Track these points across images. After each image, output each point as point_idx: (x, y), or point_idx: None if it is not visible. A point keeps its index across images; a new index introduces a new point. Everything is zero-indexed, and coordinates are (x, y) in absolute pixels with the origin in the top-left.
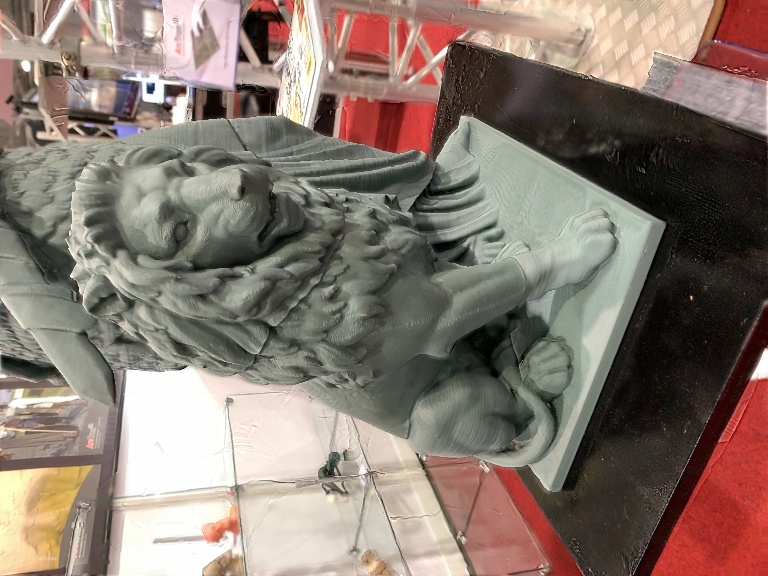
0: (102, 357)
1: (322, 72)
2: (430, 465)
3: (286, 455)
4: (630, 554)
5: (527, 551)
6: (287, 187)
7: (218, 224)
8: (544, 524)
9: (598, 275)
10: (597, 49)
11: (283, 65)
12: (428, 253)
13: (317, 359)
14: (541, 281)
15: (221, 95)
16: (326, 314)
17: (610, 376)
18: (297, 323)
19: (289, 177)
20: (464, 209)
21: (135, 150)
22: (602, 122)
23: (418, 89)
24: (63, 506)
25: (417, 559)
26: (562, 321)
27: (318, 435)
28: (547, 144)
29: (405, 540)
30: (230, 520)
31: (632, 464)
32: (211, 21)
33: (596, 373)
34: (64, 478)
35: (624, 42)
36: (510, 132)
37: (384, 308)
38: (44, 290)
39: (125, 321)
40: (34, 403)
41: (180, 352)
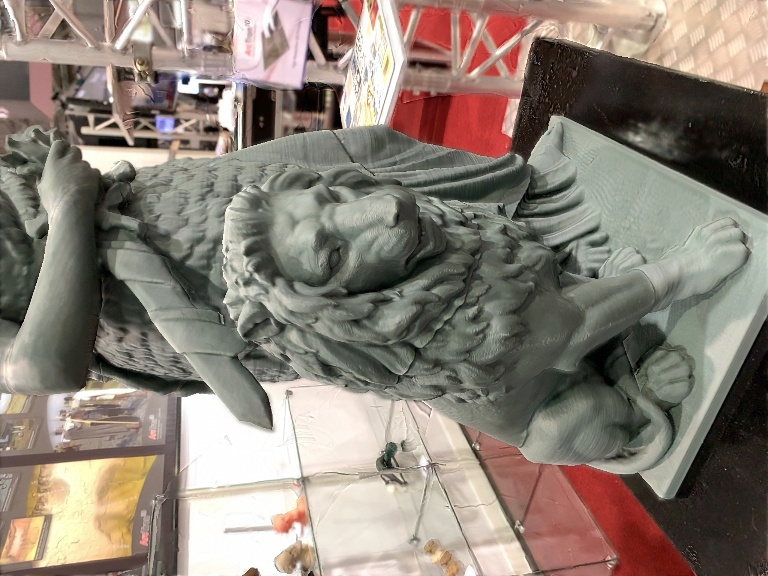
0: (255, 380)
1: (402, 73)
2: None
3: (340, 445)
4: (759, 565)
5: (585, 540)
6: (422, 207)
7: (371, 250)
8: (610, 516)
9: (726, 285)
10: (670, 35)
11: (349, 62)
12: (555, 267)
13: (457, 378)
14: (668, 293)
15: None
16: (470, 335)
17: (735, 386)
18: (442, 344)
19: (422, 196)
20: (564, 213)
21: (277, 175)
22: (725, 127)
23: (481, 81)
24: (131, 495)
25: (475, 548)
26: (682, 330)
27: (371, 425)
28: (655, 147)
29: None
30: (299, 511)
31: (762, 476)
32: (282, 22)
33: (721, 383)
34: (130, 468)
35: (701, 27)
36: (609, 133)
37: (523, 327)
38: (195, 314)
39: (271, 343)
40: (97, 395)
41: (326, 373)
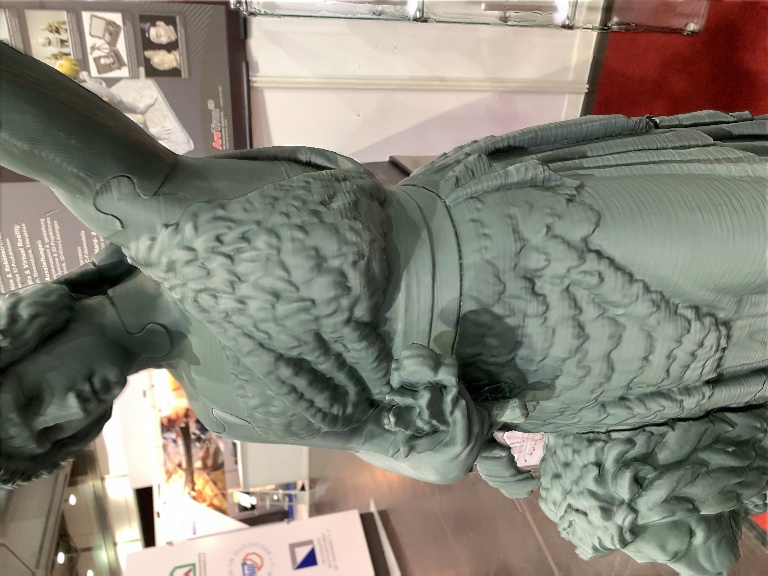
0: None
1: None
2: None
3: None
4: None
5: None
6: None
7: None
8: (729, 1)
9: None
10: None
11: None
12: None
13: None
14: None
15: None
16: None
17: None
18: None
19: None
20: None
21: (662, 518)
22: None
23: None
24: None
25: None
26: None
27: None
28: None
29: None
30: None
31: None
32: None
33: None
34: None
35: None
36: None
37: None
38: None
39: None
40: None
41: None
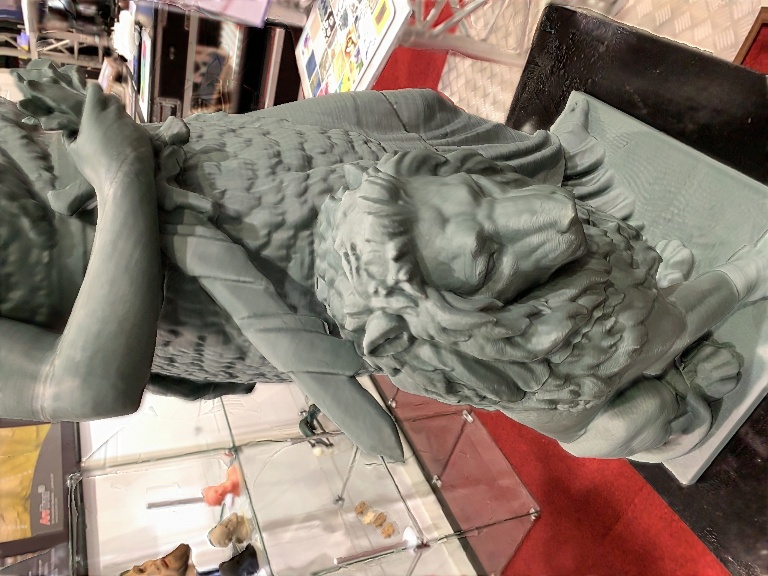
0: None
1: (404, 24)
2: (420, 418)
3: None
4: None
5: (493, 490)
6: None
7: (531, 257)
8: (535, 472)
9: None
10: (633, 10)
11: (313, 0)
12: None
13: (578, 391)
14: (745, 295)
15: (183, 15)
16: (605, 348)
17: None
18: (577, 358)
19: None
20: (598, 198)
21: (401, 156)
22: None
23: (444, 36)
24: (25, 469)
25: (396, 504)
26: (733, 328)
27: (288, 385)
28: (700, 137)
29: (382, 486)
30: (233, 483)
31: None
32: None
33: None
34: (20, 439)
35: (667, 7)
36: (643, 117)
37: (647, 337)
38: (298, 323)
39: (386, 356)
40: None
41: (448, 391)
